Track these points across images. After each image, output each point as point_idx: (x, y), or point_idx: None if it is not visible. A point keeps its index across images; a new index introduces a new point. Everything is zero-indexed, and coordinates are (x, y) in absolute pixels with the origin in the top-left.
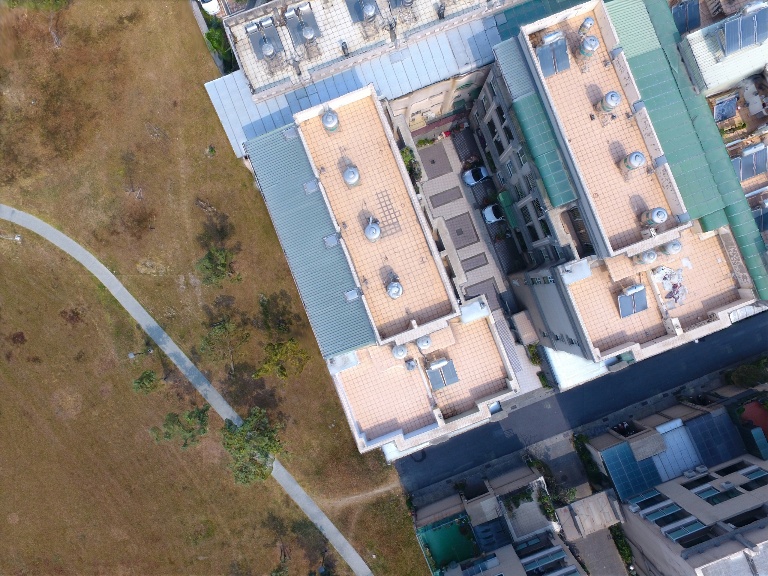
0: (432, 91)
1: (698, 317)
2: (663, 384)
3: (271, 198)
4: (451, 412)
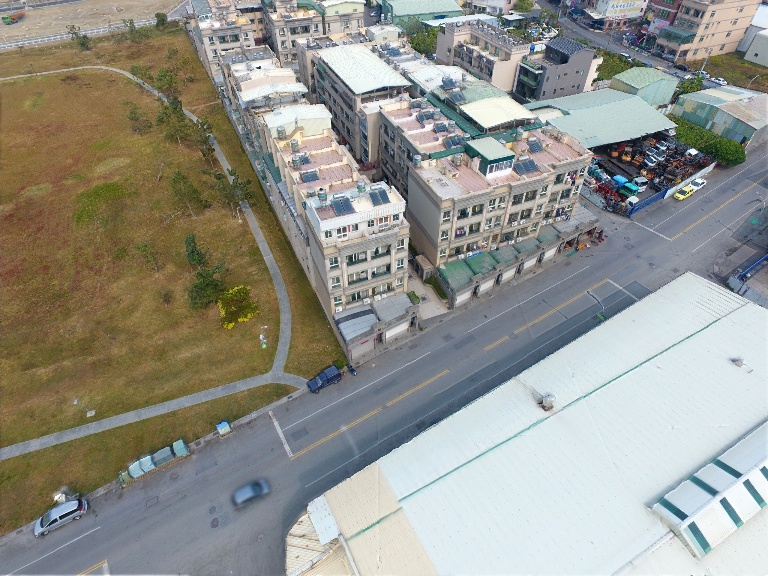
0: (248, 15)
1: None
2: None
3: (194, 3)
4: None
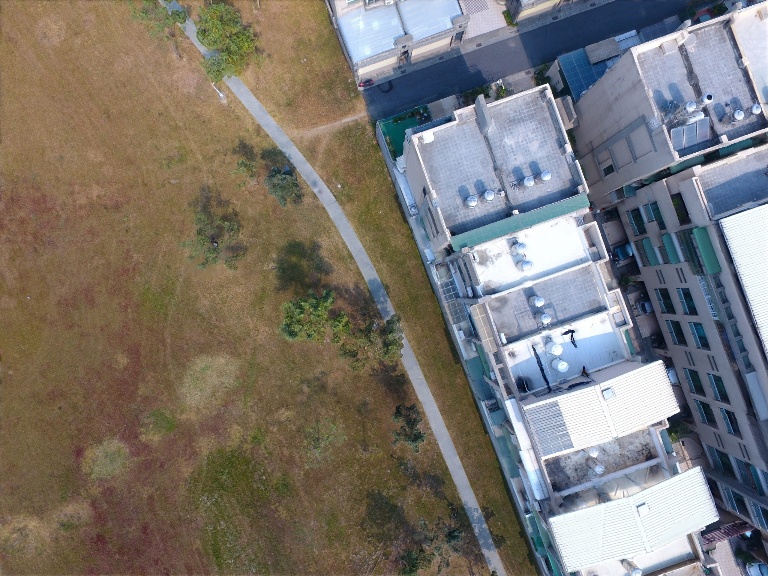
0: None
1: None
2: (623, 28)
3: None
4: None
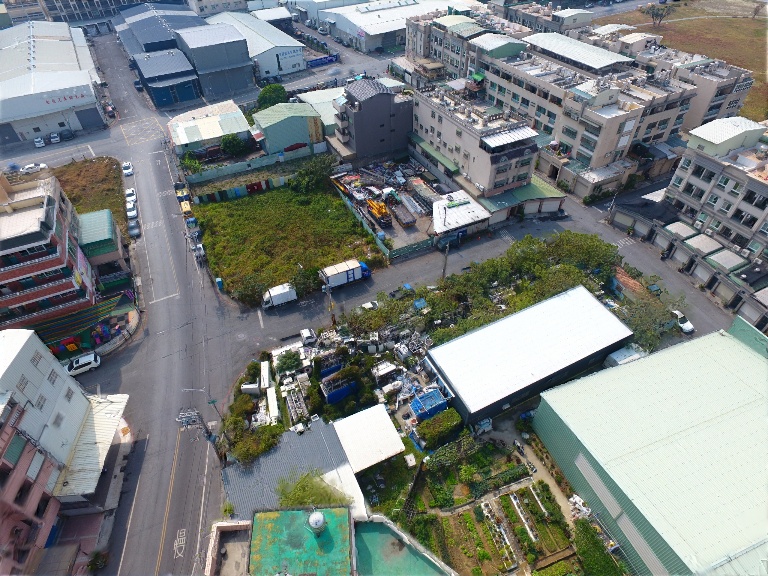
0: None
1: None
2: None
3: None
4: None
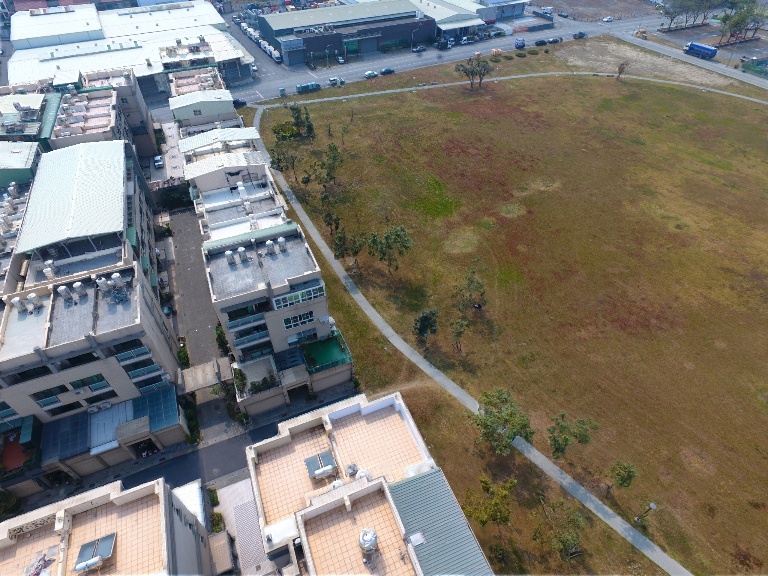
0: None
1: (29, 537)
2: None
3: None
4: (315, 431)
